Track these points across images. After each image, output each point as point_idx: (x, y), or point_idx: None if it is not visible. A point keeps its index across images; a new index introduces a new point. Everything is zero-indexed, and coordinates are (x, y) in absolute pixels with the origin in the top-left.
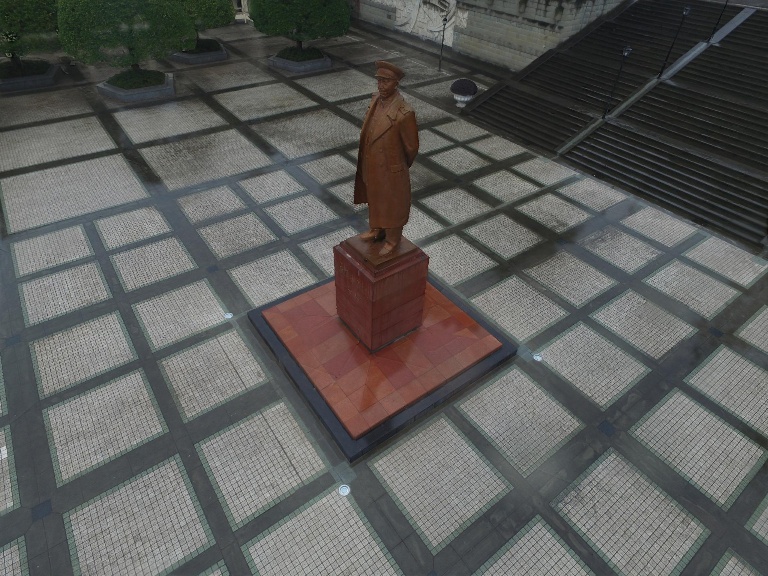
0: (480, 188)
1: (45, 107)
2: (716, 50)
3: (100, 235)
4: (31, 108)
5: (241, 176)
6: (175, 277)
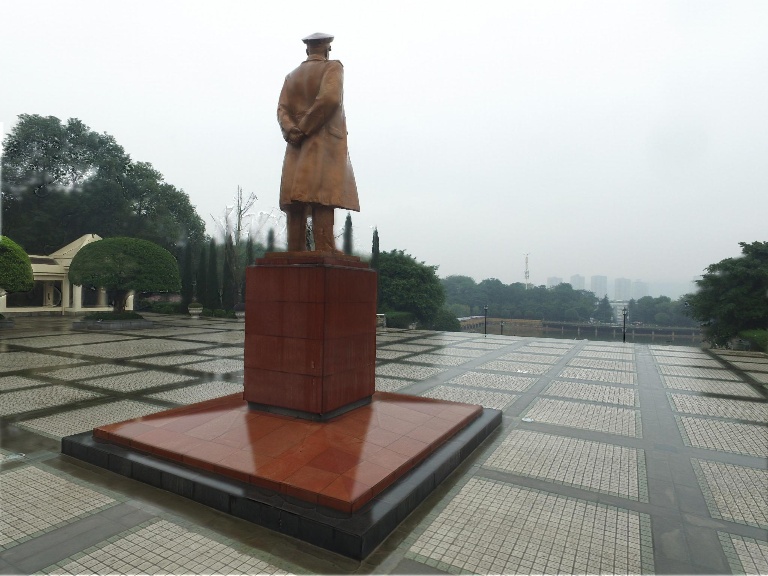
0: None
1: None
2: None
3: None
4: None
5: None
6: (677, 432)
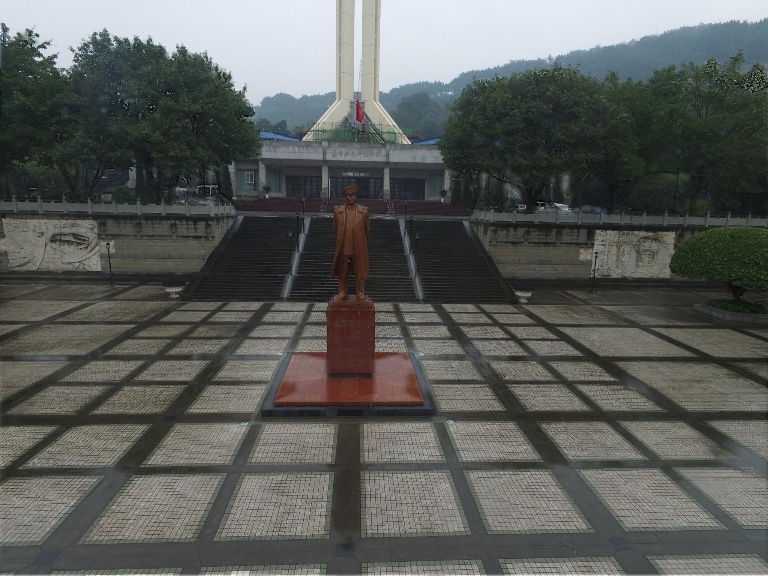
0: (272, 321)
1: None
2: (311, 236)
3: None
4: None
5: (53, 377)
6: (143, 437)
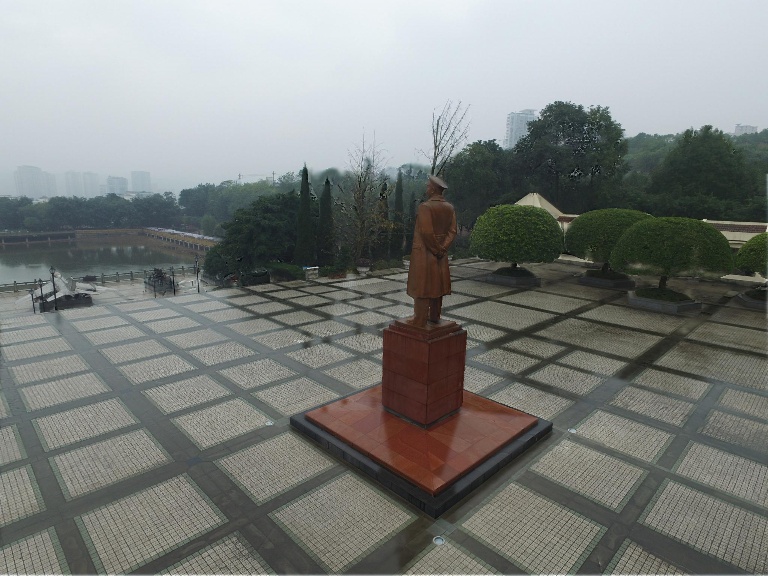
0: None
1: (580, 292)
2: None
3: None
4: (573, 290)
5: (589, 350)
6: None
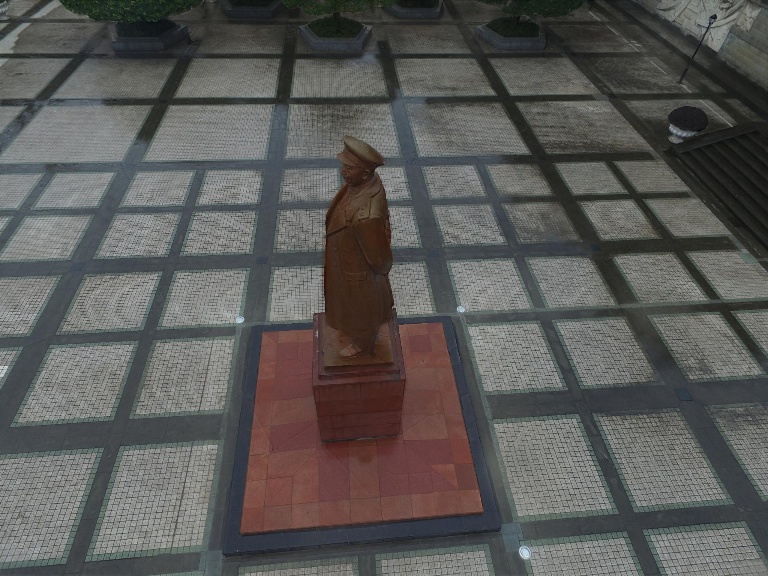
0: (619, 269)
1: (249, 40)
2: None
3: (201, 187)
4: (238, 39)
5: None
6: (227, 256)
